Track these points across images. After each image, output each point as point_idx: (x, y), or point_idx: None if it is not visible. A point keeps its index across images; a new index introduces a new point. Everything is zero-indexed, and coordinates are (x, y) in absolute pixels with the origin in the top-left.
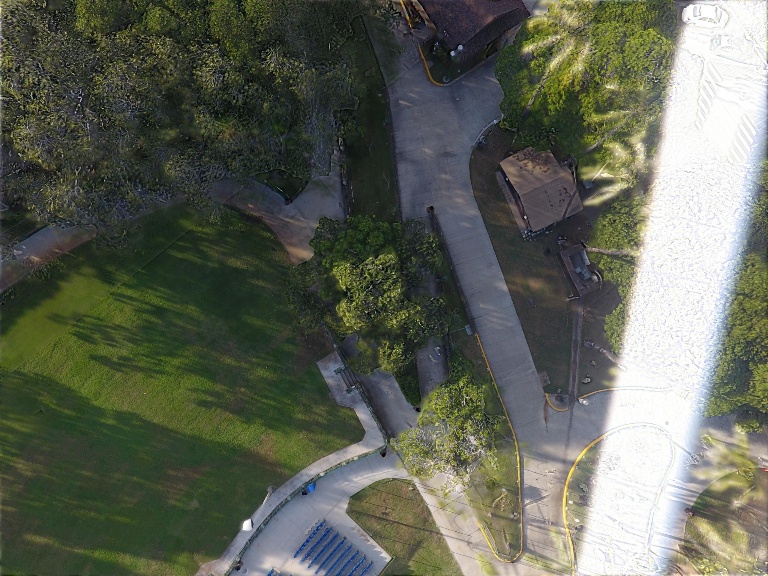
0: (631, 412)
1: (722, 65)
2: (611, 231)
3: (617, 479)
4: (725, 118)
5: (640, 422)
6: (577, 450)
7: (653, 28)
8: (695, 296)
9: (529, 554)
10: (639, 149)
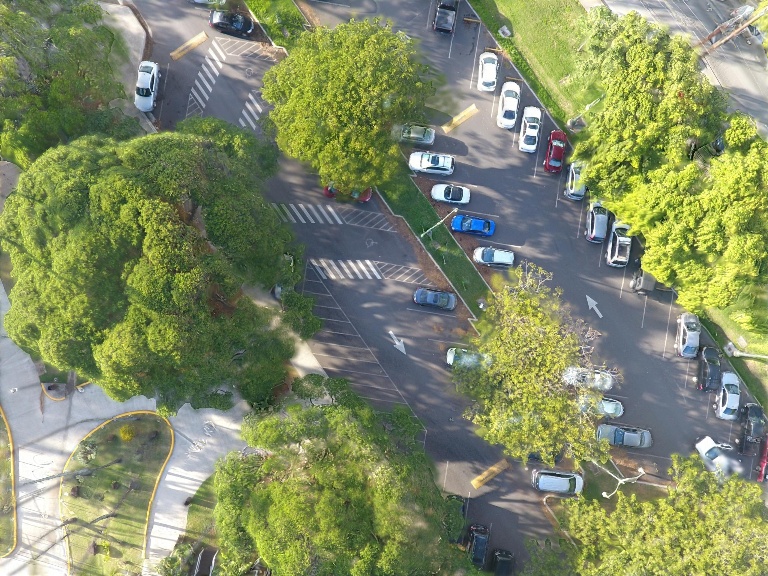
0: (132, 400)
1: (227, 42)
2: (4, 211)
3: (113, 469)
4: (230, 96)
5: (141, 410)
6: (75, 440)
7: (12, 0)
8: (29, 275)
9: (24, 549)
10: (9, 126)
